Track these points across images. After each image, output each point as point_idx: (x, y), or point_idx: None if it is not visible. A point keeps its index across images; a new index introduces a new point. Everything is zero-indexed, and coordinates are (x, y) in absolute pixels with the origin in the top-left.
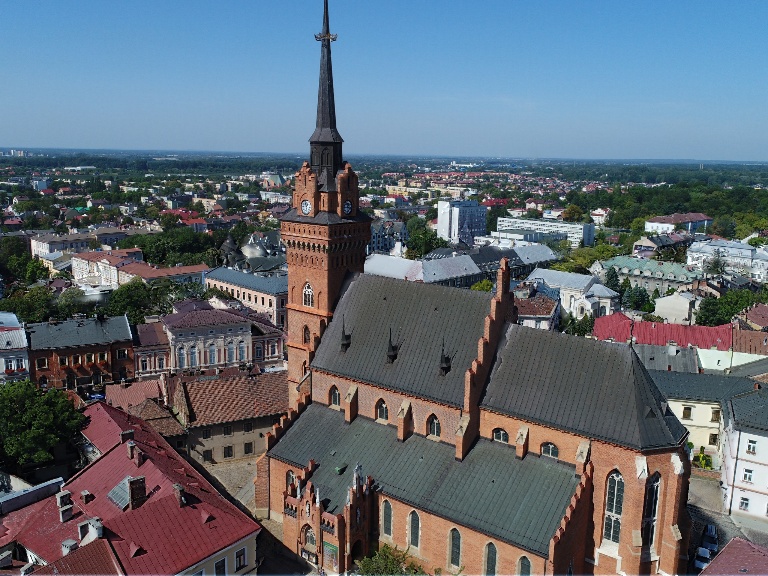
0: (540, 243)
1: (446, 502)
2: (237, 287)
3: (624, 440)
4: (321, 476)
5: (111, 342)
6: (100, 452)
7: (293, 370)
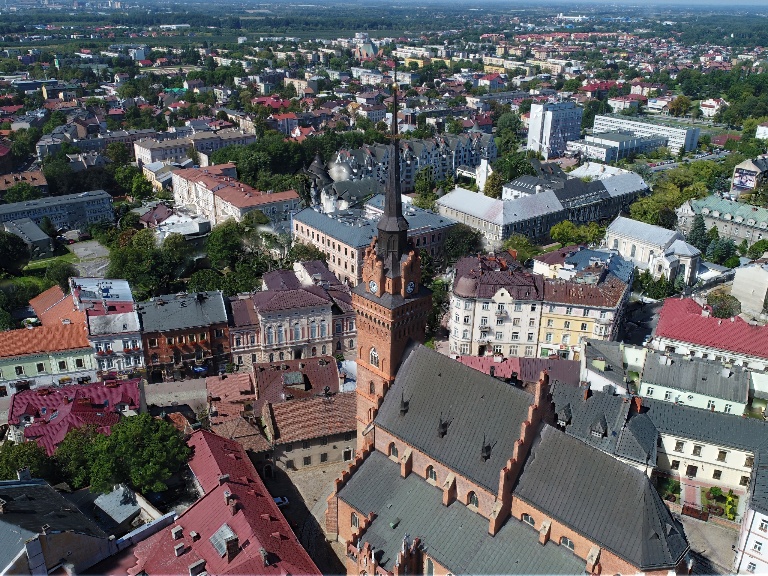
0: (631, 171)
1: (477, 574)
2: (322, 234)
3: (628, 556)
4: (378, 527)
5: (210, 325)
6: (203, 490)
7: (361, 412)
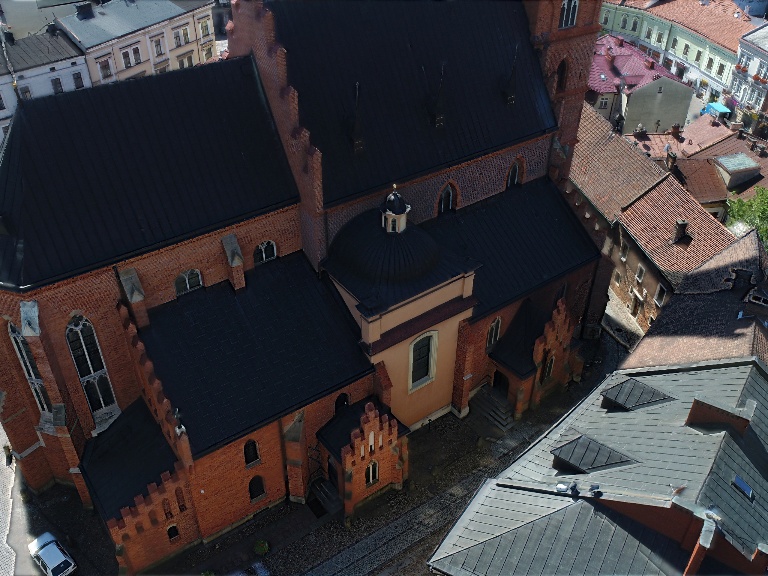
0: None
1: None
2: None
3: None
4: None
5: None
6: None
7: None
